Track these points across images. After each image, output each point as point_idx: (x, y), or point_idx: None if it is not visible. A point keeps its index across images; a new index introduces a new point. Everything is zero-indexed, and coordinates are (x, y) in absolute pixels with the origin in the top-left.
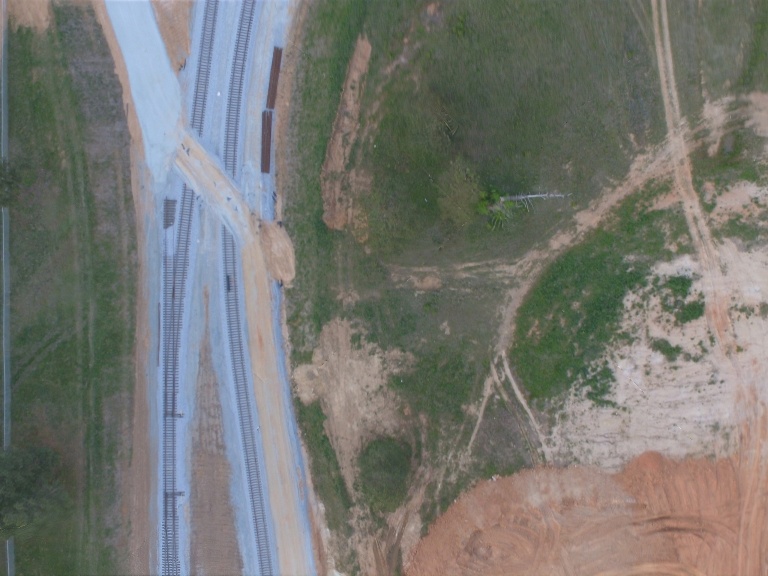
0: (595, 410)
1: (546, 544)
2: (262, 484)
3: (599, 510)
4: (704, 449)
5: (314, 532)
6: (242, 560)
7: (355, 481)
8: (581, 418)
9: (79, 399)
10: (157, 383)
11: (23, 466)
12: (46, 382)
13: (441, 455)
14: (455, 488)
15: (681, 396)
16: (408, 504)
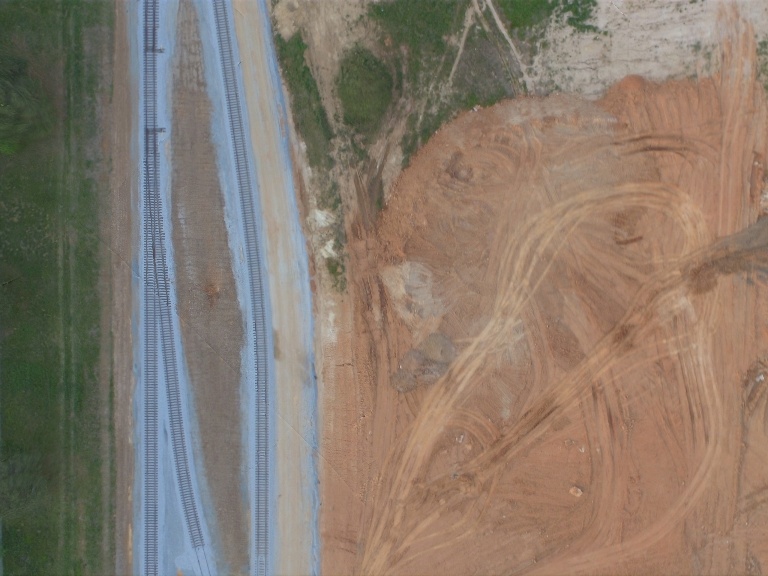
0: (576, 36)
1: (527, 163)
2: (243, 120)
3: (580, 129)
4: (686, 69)
5: (296, 171)
6: (223, 198)
7: (336, 112)
8: (562, 45)
9: (59, 28)
10: (137, 19)
11: (1, 63)
12: (26, 10)
13: (422, 86)
14: (436, 119)
15: (662, 17)
16: (389, 136)
